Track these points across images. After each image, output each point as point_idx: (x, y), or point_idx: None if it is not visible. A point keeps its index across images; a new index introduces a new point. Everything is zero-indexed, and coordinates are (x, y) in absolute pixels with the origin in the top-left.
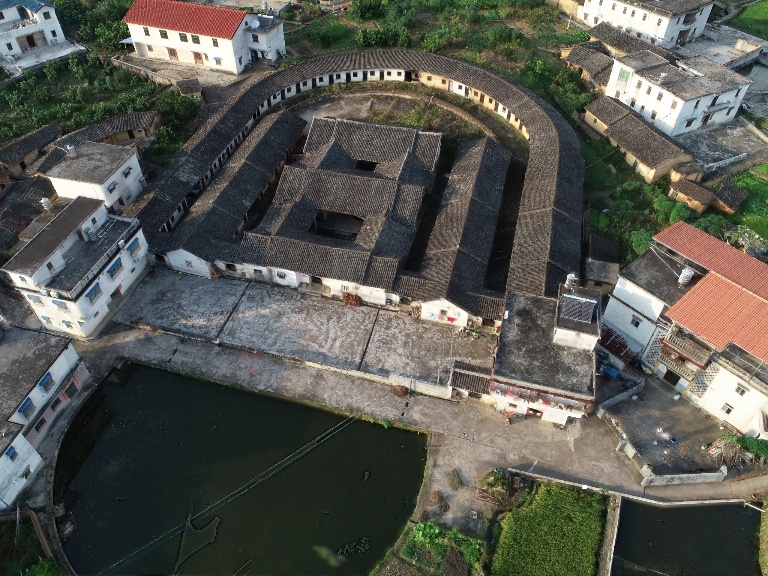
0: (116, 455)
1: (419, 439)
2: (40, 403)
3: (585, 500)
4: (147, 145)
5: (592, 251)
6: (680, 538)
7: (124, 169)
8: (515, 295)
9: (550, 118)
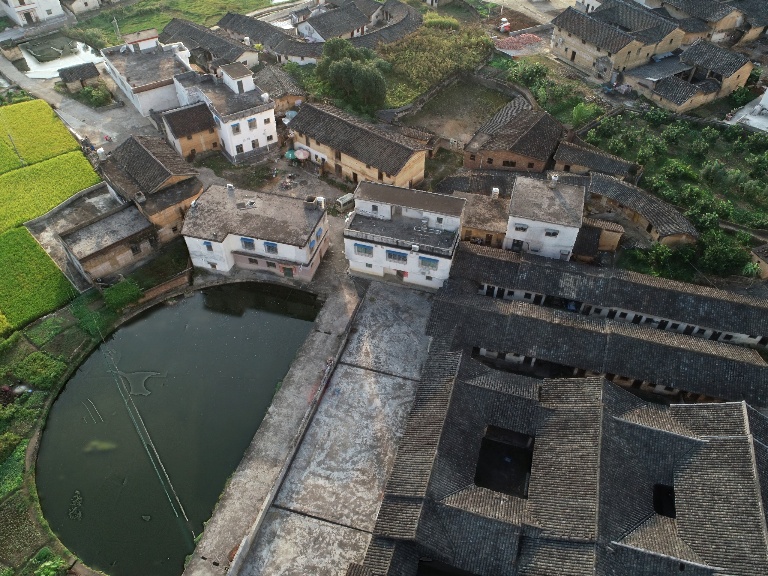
0: (228, 316)
1: None
2: (260, 252)
3: None
4: (642, 246)
5: None
6: None
7: (551, 228)
8: None
9: None
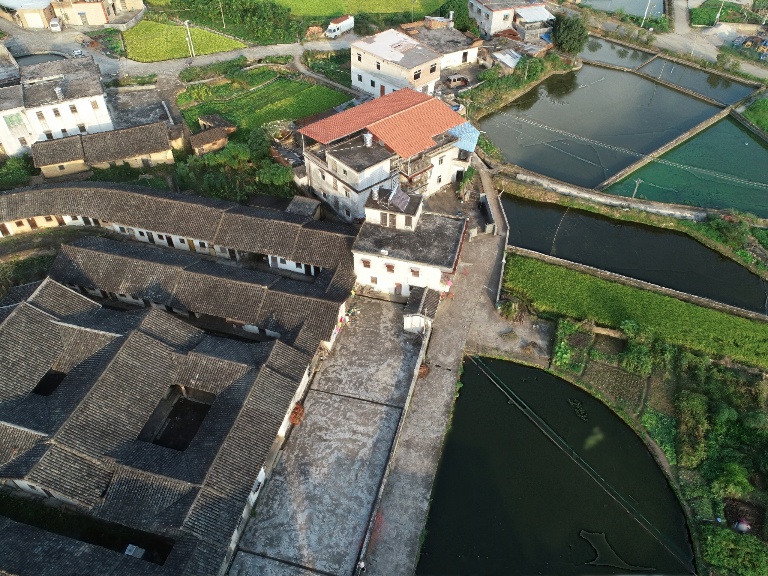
0: None
1: (469, 362)
2: None
3: (514, 263)
4: None
5: (274, 208)
6: (529, 227)
7: None
8: (356, 246)
9: (58, 188)
